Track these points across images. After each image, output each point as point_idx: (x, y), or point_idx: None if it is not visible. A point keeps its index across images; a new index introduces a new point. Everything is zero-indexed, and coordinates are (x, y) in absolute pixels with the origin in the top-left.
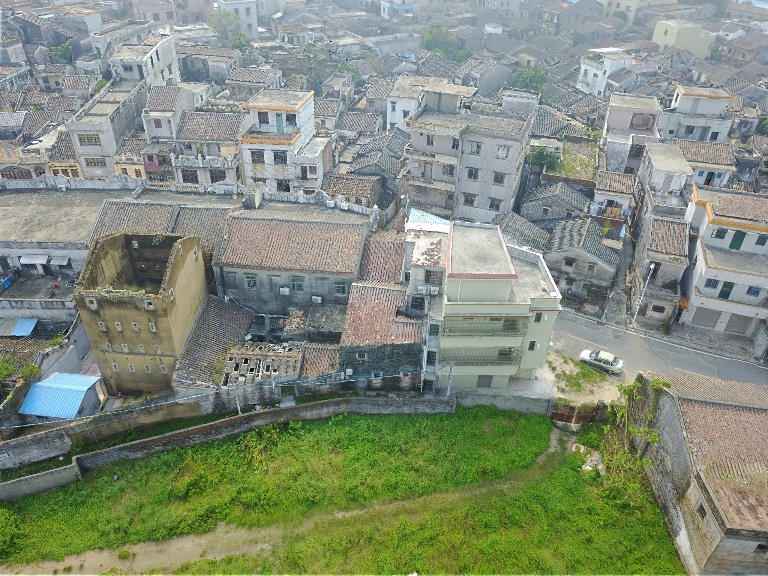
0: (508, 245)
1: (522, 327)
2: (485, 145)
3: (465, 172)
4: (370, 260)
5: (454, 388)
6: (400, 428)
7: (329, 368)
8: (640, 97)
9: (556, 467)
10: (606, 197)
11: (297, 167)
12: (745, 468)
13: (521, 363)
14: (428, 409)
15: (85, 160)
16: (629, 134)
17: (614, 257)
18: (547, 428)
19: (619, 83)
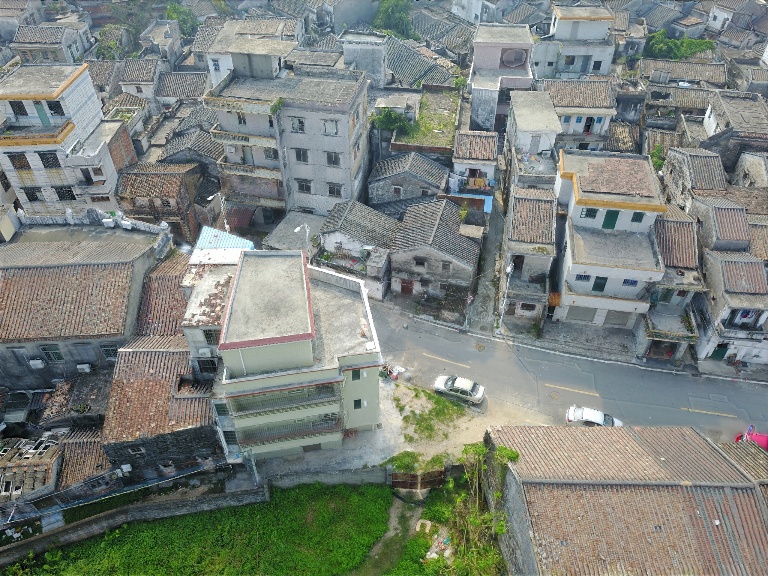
0: (322, 271)
1: (338, 389)
2: (308, 120)
3: (292, 154)
4: (151, 306)
5: (275, 458)
6: (198, 535)
7: (97, 469)
8: (510, 26)
9: (394, 561)
10: (467, 166)
11: (75, 169)
12: (606, 573)
13: (348, 425)
14: (234, 502)
15: None
16: (499, 75)
17: (473, 249)
18: (386, 504)
19: (495, 4)
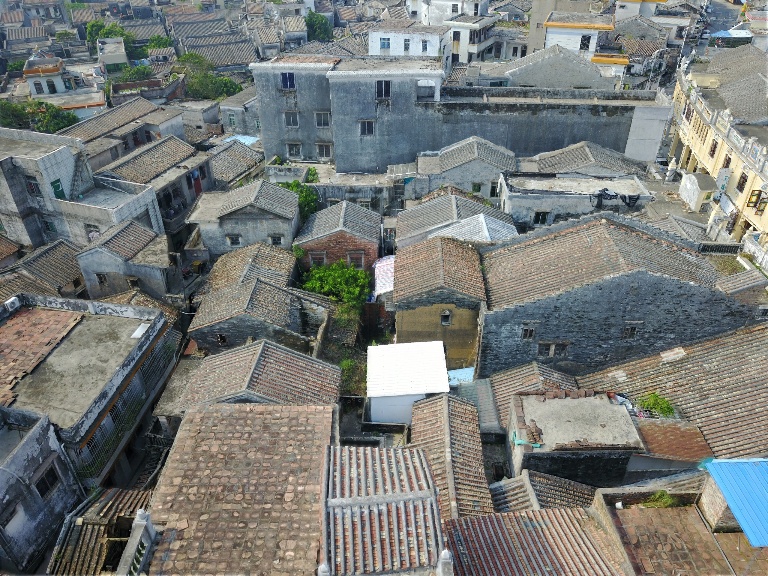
0: None
1: None
2: None
3: None
4: None
5: None
6: None
7: None
8: None
9: None
10: None
11: None
12: None
13: None
14: None
15: None
16: None
17: None
18: None
19: (332, 12)
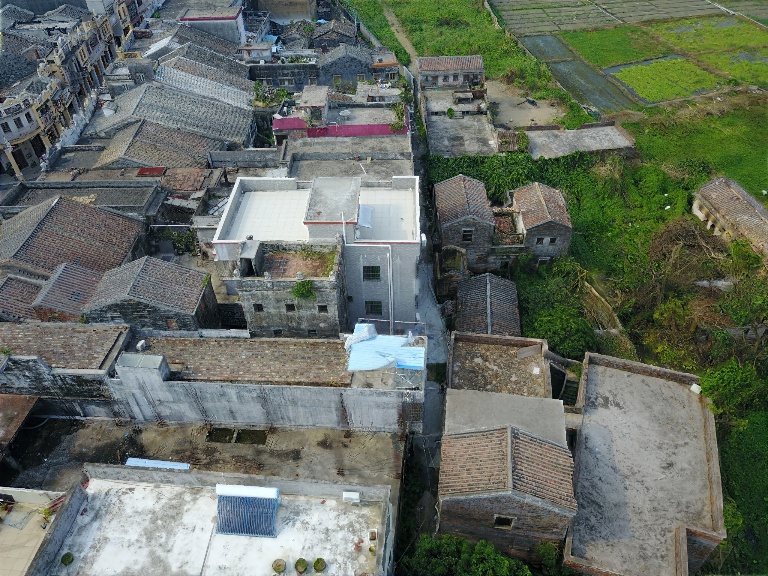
0: None
1: None
2: None
3: None
4: None
5: None
6: None
7: None
8: None
9: None
10: None
11: None
12: None
13: None
14: None
15: (107, 12)
16: None
17: None
18: None
19: None
